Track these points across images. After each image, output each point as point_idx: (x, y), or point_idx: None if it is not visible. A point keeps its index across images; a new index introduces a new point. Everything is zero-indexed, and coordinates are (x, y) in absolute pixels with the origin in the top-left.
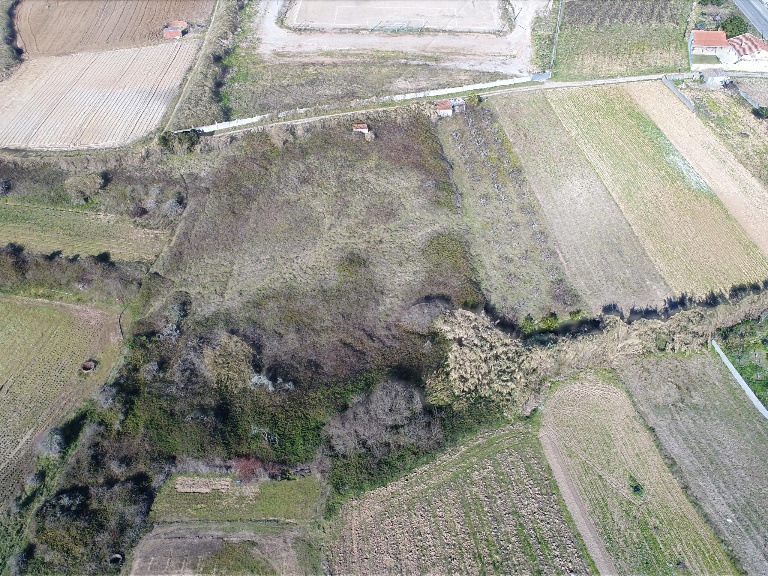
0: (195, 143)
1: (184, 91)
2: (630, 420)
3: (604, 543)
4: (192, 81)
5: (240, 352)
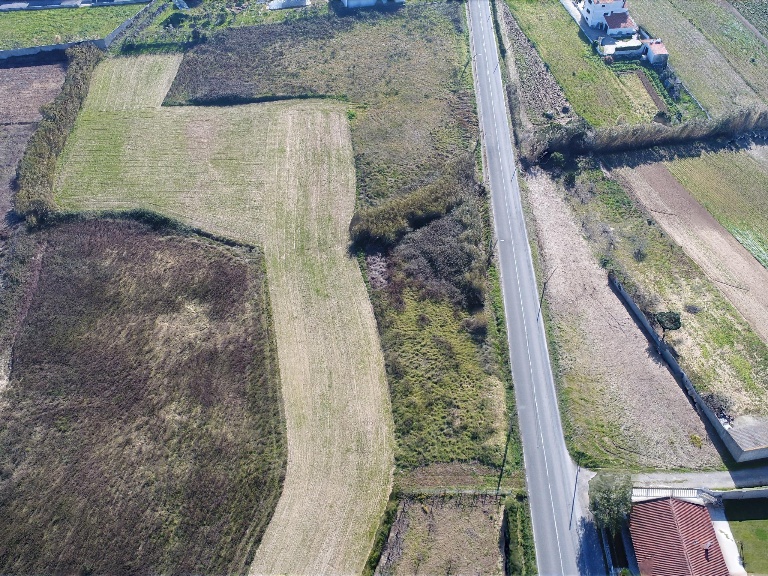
0: None
1: None
2: (761, 88)
3: (765, 45)
4: None
5: None
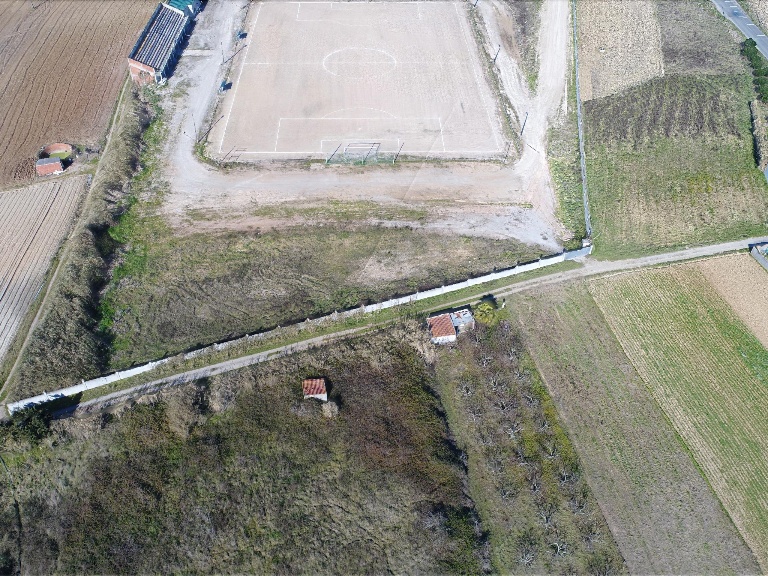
0: (43, 434)
1: (49, 290)
2: None
3: None
4: (58, 279)
5: None
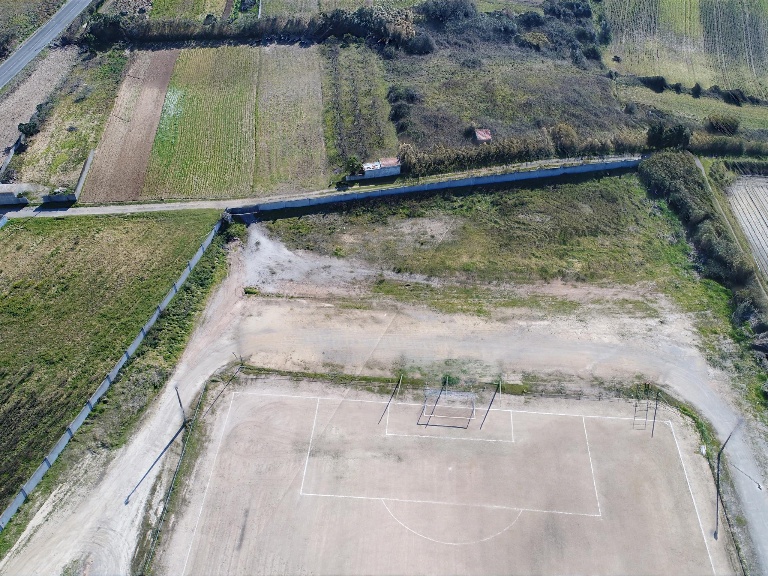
0: None
1: None
2: (327, 8)
3: None
4: None
5: (529, 37)
